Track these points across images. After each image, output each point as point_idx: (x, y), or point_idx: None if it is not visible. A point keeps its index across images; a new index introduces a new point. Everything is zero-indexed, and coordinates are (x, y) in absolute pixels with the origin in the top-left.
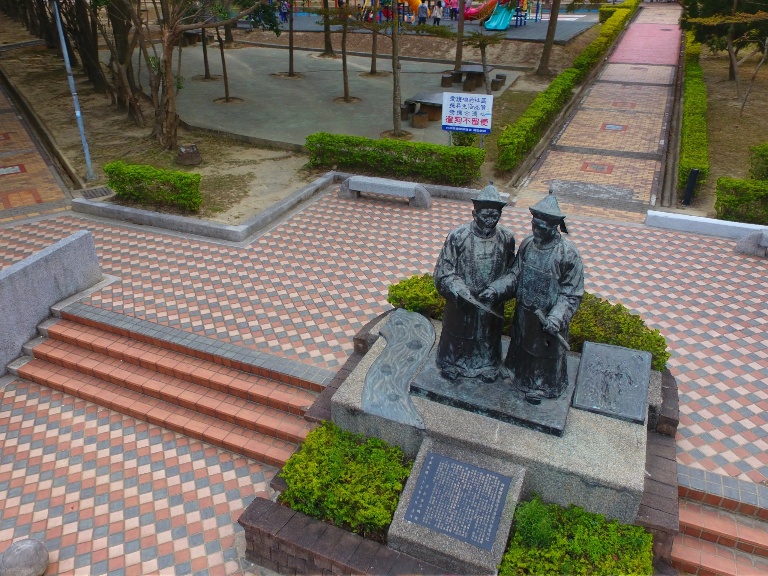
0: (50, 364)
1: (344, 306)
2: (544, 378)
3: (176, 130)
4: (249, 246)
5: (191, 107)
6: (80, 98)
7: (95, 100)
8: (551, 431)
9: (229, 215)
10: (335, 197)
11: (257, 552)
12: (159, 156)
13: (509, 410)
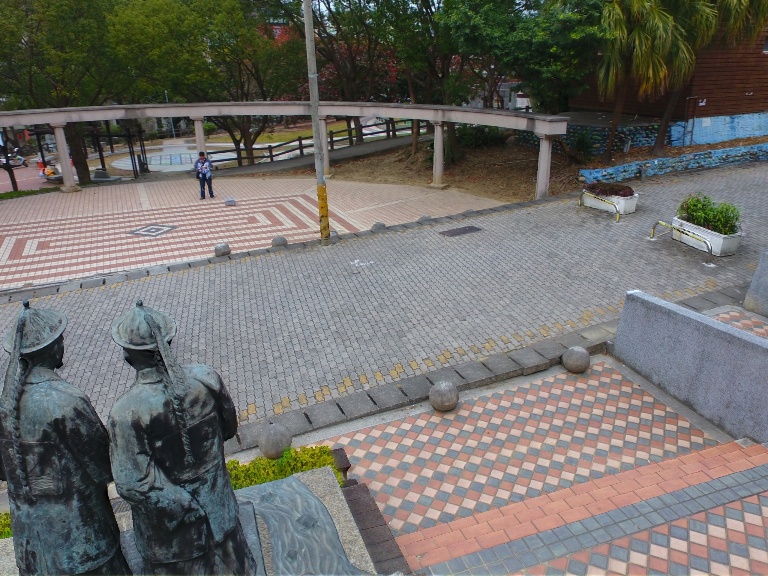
0: None
1: None
2: None
3: None
4: None
5: None
6: None
7: None
8: None
9: None
10: None
11: None
12: None
13: None
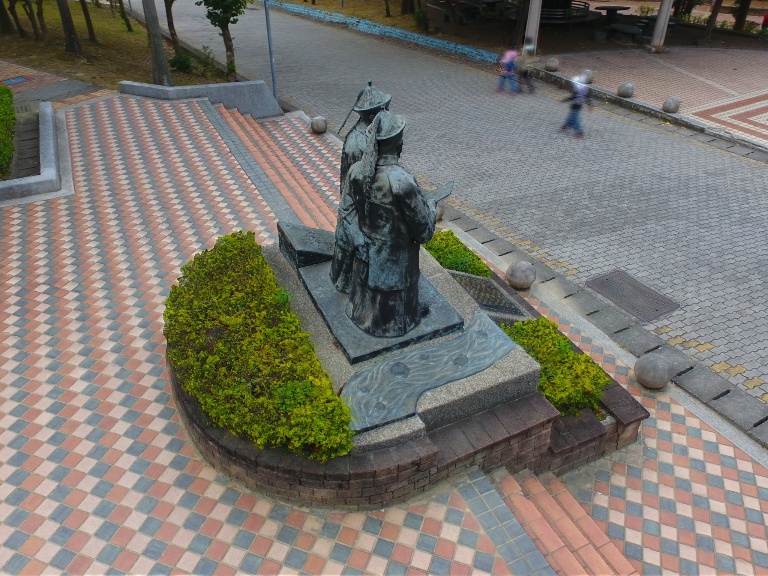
0: None
1: None
2: None
3: None
4: None
5: None
6: None
7: None
8: None
9: None
10: None
11: None
12: None
13: None
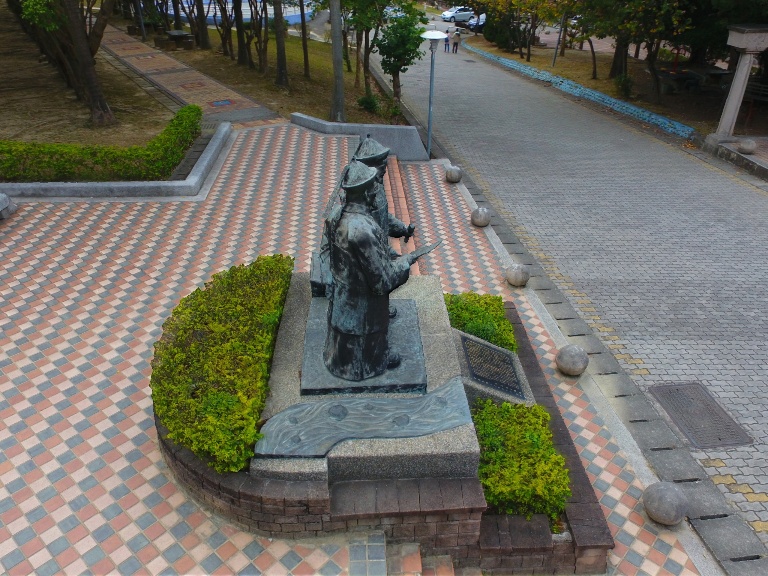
0: None
1: None
2: None
3: None
4: None
5: None
6: None
7: None
8: None
9: None
10: None
11: None
12: None
13: (415, 323)
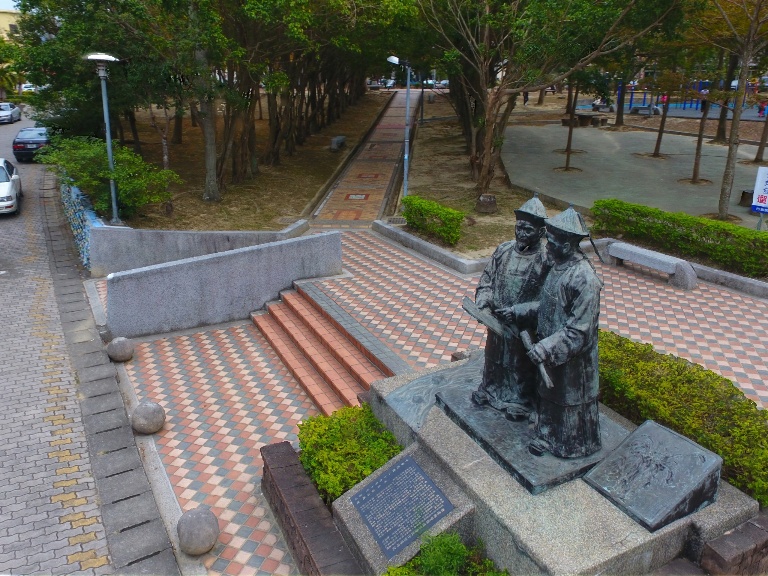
0: (273, 319)
1: None
2: (552, 428)
3: (488, 183)
4: (469, 278)
5: (528, 171)
6: (450, 157)
7: (460, 159)
8: (525, 483)
9: (478, 254)
10: (594, 260)
11: (265, 483)
12: (466, 203)
13: (500, 446)
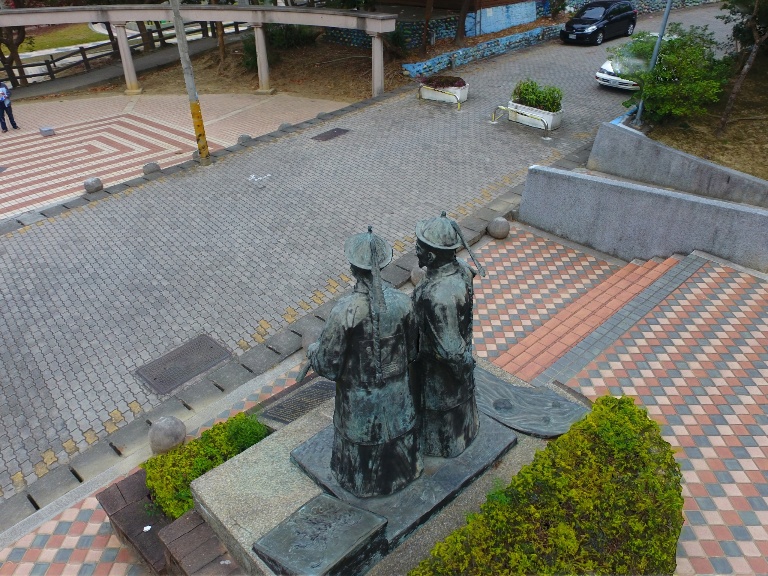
0: None
1: (715, 441)
2: None
3: None
4: None
5: None
6: None
7: None
8: None
9: None
10: None
11: None
12: None
13: None
